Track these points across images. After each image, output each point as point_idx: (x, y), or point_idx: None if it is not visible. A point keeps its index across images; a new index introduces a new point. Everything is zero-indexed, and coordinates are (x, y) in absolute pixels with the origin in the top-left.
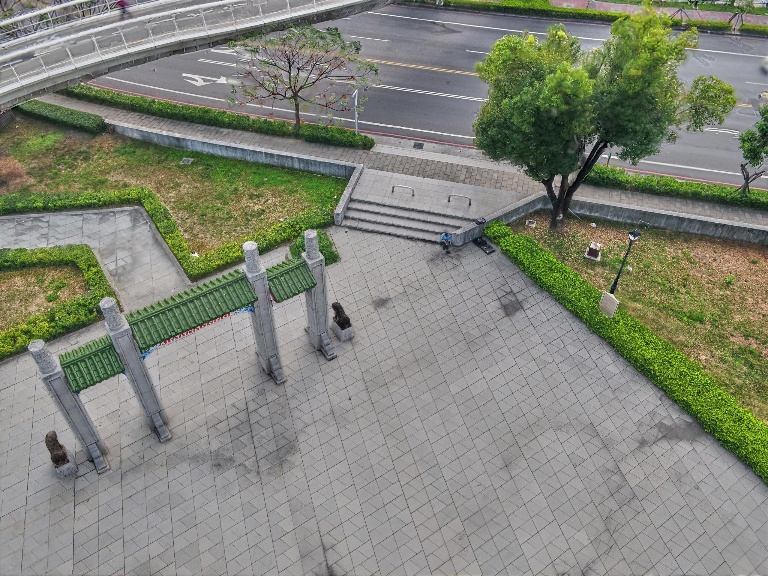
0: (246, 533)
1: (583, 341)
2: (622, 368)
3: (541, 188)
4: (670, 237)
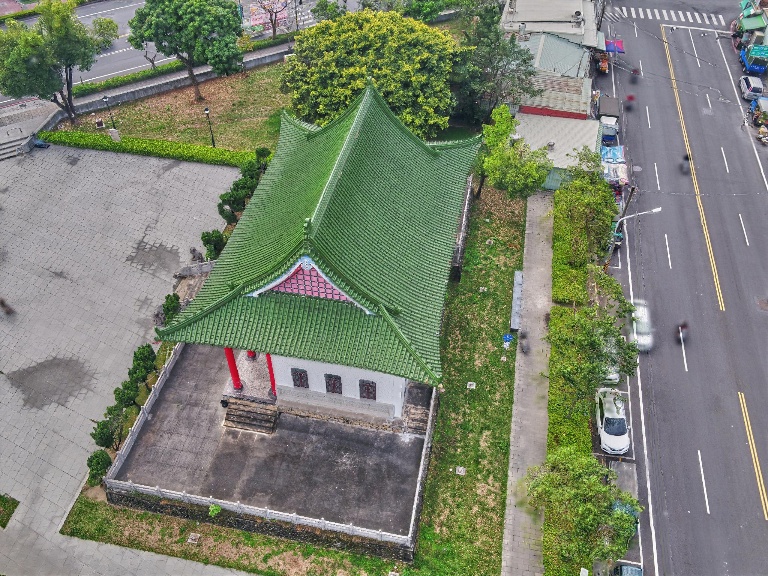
0: (7, 284)
1: (115, 157)
2: (137, 158)
3: (55, 109)
4: (133, 103)
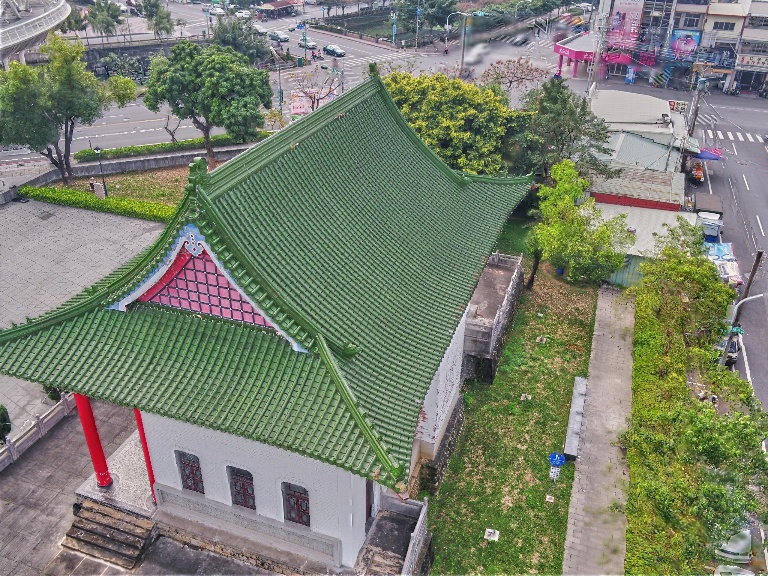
0: None
1: (95, 216)
2: (120, 219)
3: None
4: (141, 173)
